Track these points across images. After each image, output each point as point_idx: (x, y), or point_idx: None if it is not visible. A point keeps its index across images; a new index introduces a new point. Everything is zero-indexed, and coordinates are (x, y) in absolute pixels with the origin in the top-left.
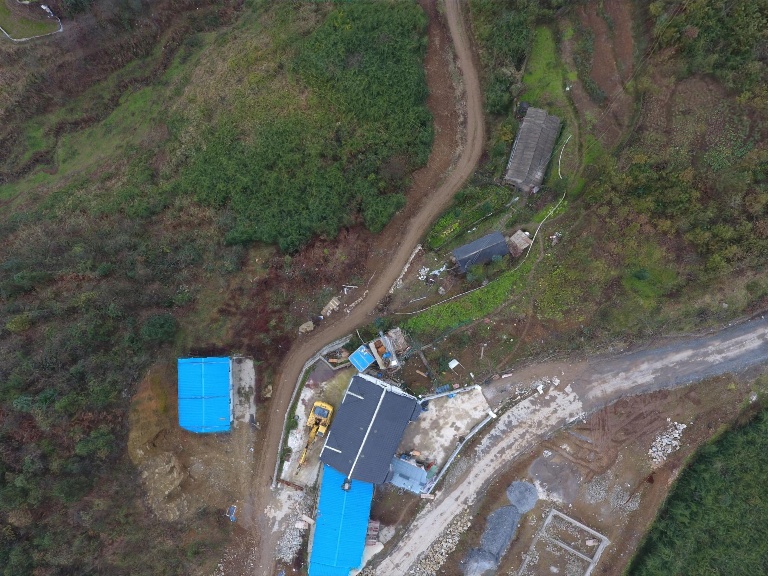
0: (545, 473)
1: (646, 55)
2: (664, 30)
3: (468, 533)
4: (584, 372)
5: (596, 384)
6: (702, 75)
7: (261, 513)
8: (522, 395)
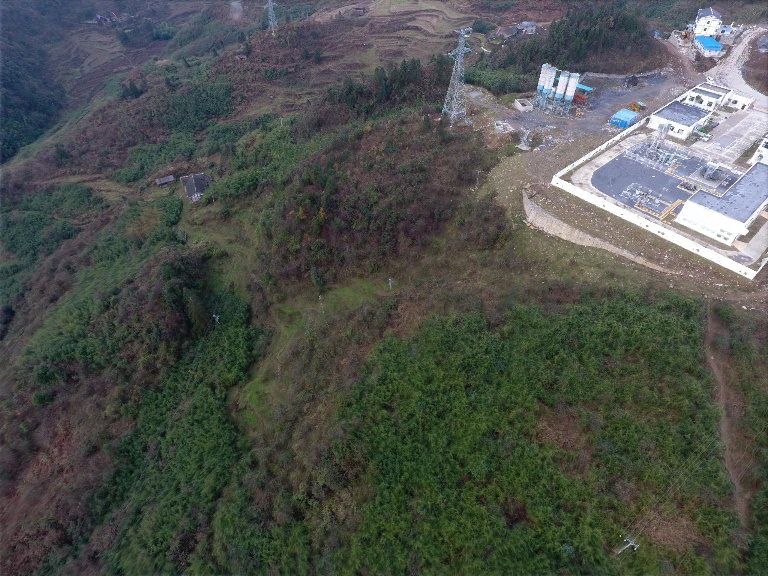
0: (767, 36)
1: (729, 7)
2: (731, 0)
3: (752, 48)
4: (762, 25)
5: (767, 26)
6: (748, 4)
7: (677, 52)
8: (746, 29)
